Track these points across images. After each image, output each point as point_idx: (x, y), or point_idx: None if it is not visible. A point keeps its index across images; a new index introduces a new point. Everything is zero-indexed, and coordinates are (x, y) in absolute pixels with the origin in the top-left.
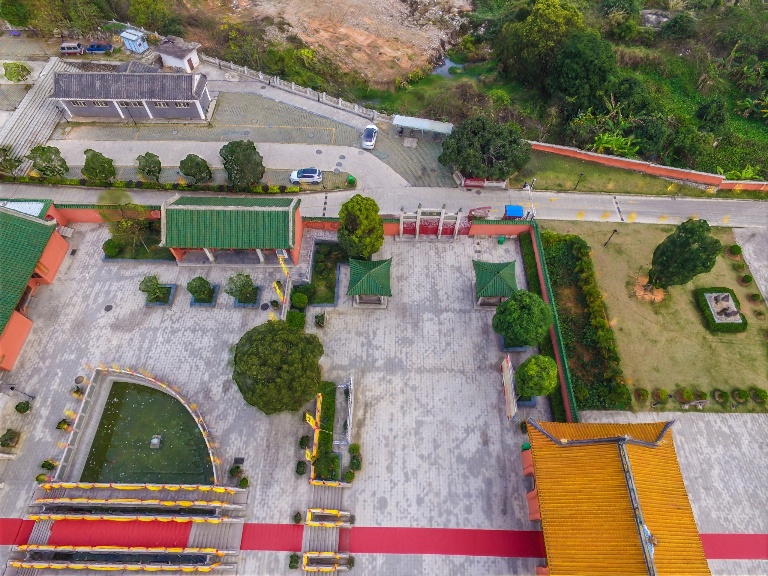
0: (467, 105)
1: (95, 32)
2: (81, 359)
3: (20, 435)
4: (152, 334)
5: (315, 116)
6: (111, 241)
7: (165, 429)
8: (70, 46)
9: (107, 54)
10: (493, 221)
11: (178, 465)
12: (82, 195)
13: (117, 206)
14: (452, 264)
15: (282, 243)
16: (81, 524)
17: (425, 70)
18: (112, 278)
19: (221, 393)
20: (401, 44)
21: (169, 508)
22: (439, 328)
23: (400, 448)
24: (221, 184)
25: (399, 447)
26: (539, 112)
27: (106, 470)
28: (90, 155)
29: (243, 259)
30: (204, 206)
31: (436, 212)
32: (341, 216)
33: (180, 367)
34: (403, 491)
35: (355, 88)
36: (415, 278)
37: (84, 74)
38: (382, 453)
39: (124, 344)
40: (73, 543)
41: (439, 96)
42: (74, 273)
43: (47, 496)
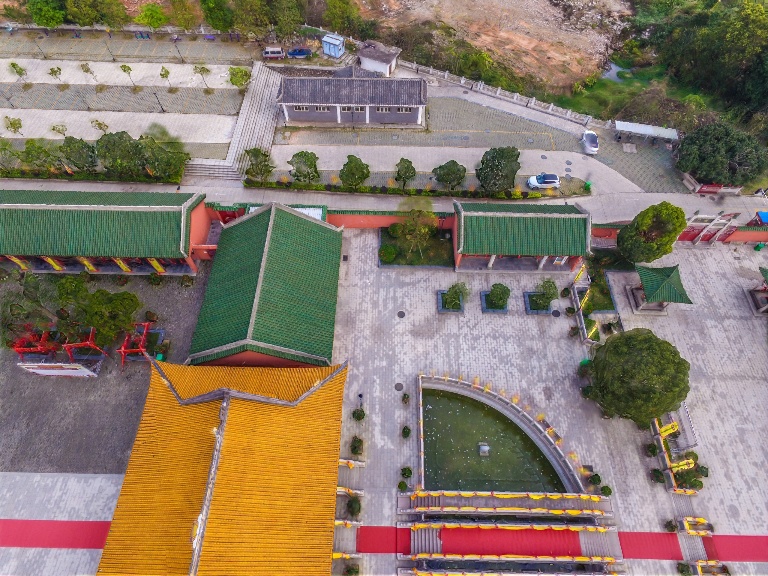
0: (662, 110)
1: (290, 36)
2: (393, 366)
3: (362, 442)
4: (455, 341)
5: (527, 121)
6: (388, 247)
7: (486, 436)
8: (274, 50)
9: (307, 58)
10: (759, 228)
11: (512, 472)
12: (329, 200)
13: (390, 212)
14: (716, 271)
15: (579, 250)
16: (468, 532)
17: (596, 75)
18: (394, 284)
19: (545, 400)
20: (567, 48)
21: (550, 516)
22: (726, 335)
23: (731, 456)
24: (460, 189)
25: (730, 455)
26: (744, 118)
27: (442, 477)
28: (354, 161)
29: (518, 265)
30: (504, 213)
31: (709, 219)
32: (647, 223)
33: (495, 374)
34: (750, 499)
35: (532, 92)
36: (685, 285)
37: (312, 79)
38: (715, 461)
39: (430, 351)
40: (468, 552)
41: (633, 101)
42: (354, 279)
43: (415, 504)
